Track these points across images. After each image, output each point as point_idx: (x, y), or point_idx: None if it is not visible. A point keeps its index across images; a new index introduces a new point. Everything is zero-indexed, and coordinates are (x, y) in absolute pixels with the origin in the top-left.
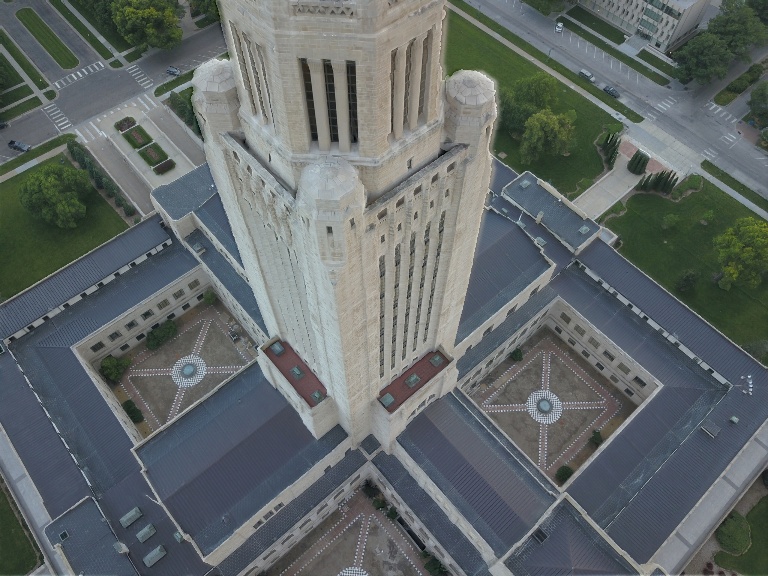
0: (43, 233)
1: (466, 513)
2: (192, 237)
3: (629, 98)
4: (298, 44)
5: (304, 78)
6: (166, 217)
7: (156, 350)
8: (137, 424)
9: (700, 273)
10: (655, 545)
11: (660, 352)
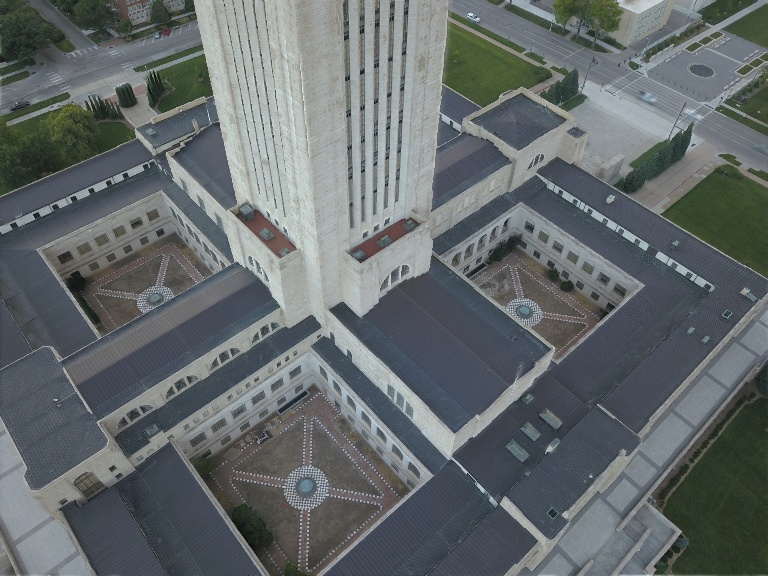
0: None
1: (482, 178)
2: (126, 447)
3: (34, 97)
4: None
5: None
6: (88, 471)
7: None
8: None
9: None
10: None
11: None
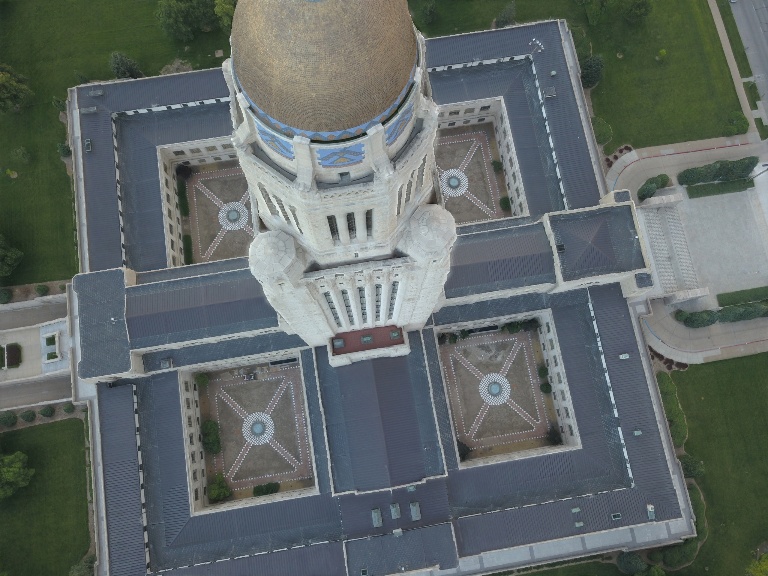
0: (14, 506)
1: (517, 285)
2: (147, 364)
3: None
4: (402, 183)
5: (398, 194)
6: None
7: (221, 448)
8: (279, 490)
9: (434, 0)
10: (594, 184)
11: (478, 79)
